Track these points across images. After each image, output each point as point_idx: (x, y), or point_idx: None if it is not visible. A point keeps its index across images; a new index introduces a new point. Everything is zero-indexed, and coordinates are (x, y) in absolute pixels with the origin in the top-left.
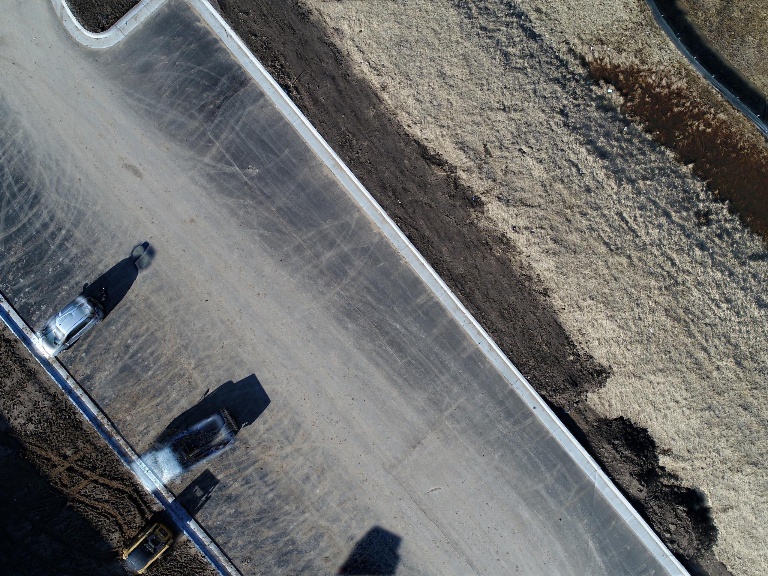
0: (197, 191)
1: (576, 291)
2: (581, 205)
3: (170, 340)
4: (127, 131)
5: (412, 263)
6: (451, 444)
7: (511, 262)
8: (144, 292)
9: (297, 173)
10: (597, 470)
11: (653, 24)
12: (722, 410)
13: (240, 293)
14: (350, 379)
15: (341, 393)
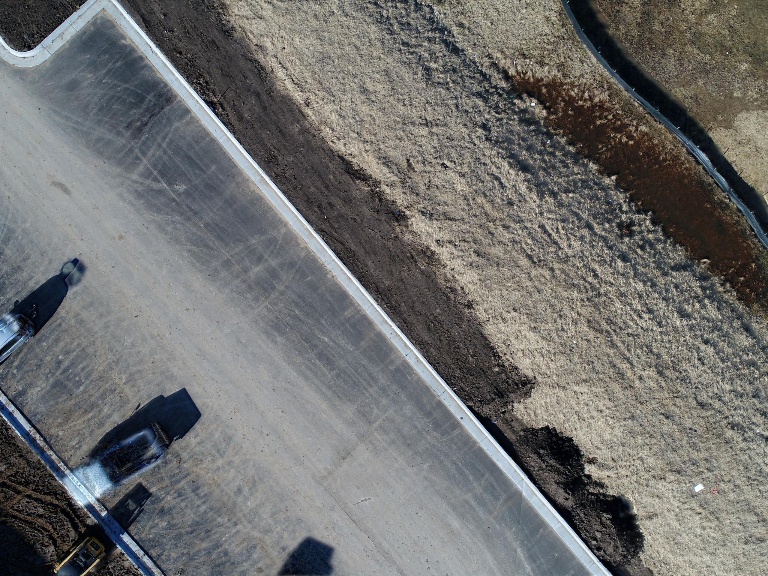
0: (125, 208)
1: (500, 303)
2: (504, 218)
3: (101, 356)
4: (55, 149)
5: (339, 277)
6: (380, 455)
7: (436, 275)
8: (74, 308)
9: (224, 189)
10: (524, 479)
11: (575, 38)
12: (645, 418)
13: (169, 308)
14: (279, 392)
15: (271, 406)
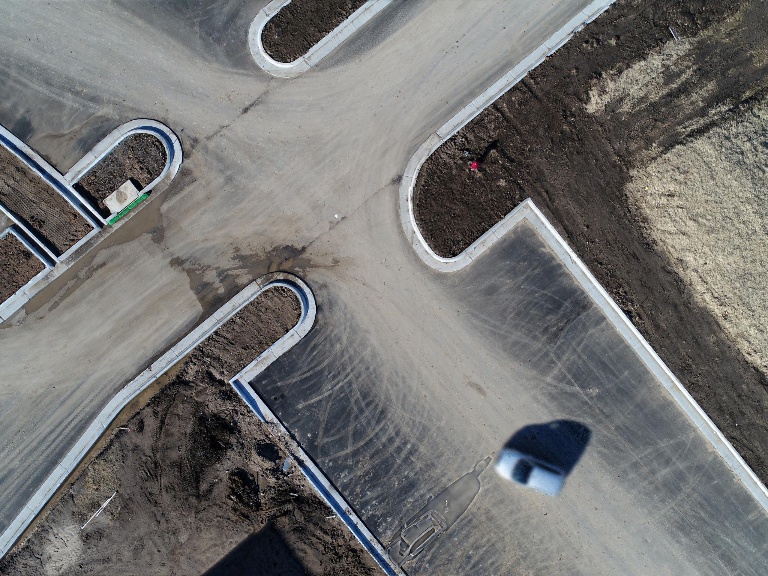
0: (539, 409)
1: None
2: None
3: (510, 551)
4: (472, 351)
5: (745, 482)
6: None
7: None
8: (486, 505)
9: (636, 394)
10: None
11: None
12: None
13: (578, 507)
14: None
15: None
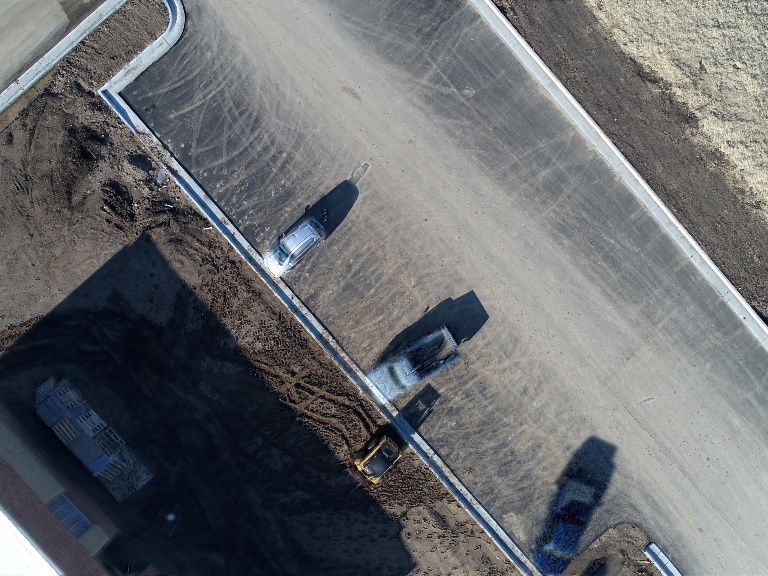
0: (415, 113)
1: None
2: None
3: (390, 259)
4: (346, 55)
5: (626, 179)
6: (663, 355)
7: (724, 176)
8: (365, 213)
9: (513, 93)
10: None
11: None
12: None
13: (459, 212)
14: (566, 294)
15: (557, 308)
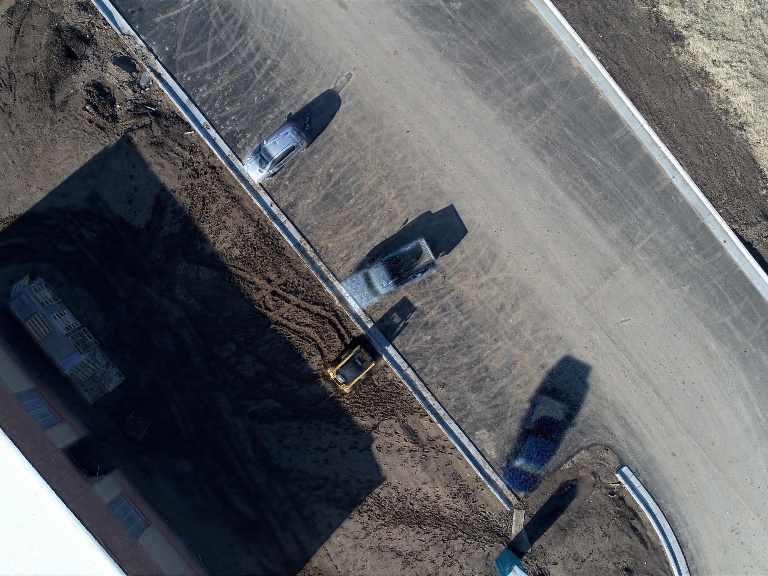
0: (401, 23)
1: None
2: None
3: (371, 170)
4: None
5: (610, 97)
6: (642, 276)
7: (709, 96)
8: (347, 122)
9: (499, 7)
10: None
11: None
12: None
13: (441, 125)
14: (546, 211)
15: (537, 225)
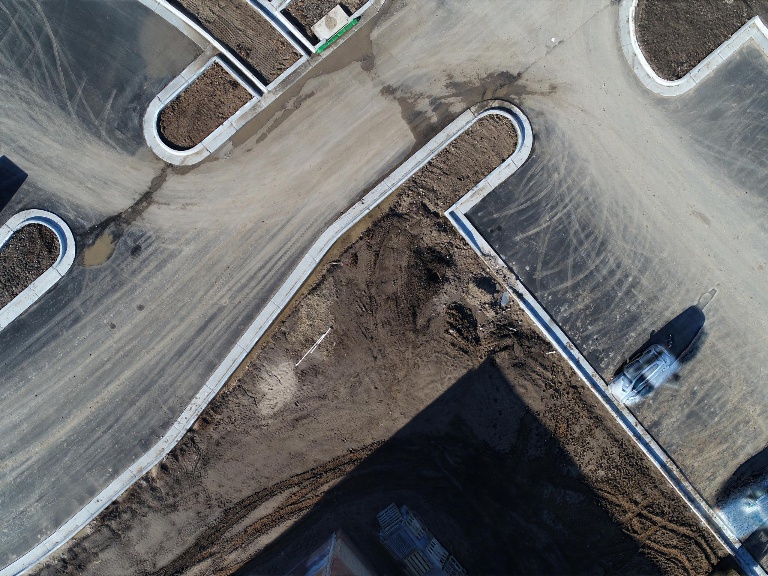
0: (766, 238)
1: None
2: None
3: (736, 387)
4: (696, 179)
5: None
6: None
7: None
8: (710, 339)
9: None
10: None
11: None
12: None
13: None
14: None
15: None
